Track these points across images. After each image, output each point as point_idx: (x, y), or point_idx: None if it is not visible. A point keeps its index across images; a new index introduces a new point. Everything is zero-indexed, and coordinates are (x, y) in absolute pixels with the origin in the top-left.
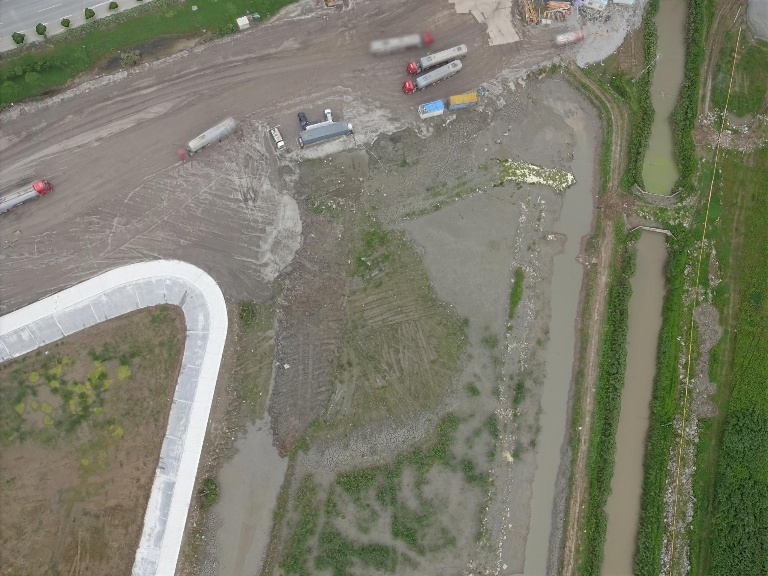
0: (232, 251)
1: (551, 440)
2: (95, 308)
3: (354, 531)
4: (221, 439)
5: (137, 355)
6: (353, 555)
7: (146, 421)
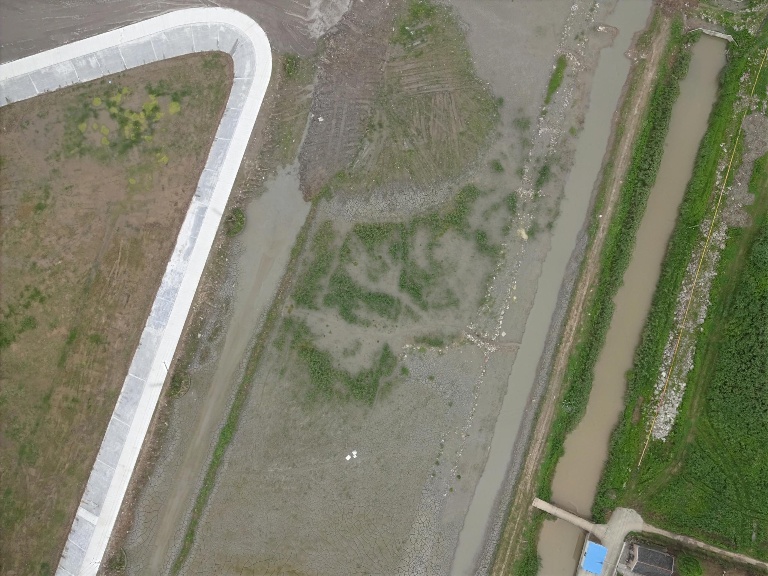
0: (284, 6)
1: (569, 226)
2: (155, 46)
3: (364, 278)
4: (253, 175)
5: (187, 94)
6: (360, 298)
7: (189, 153)
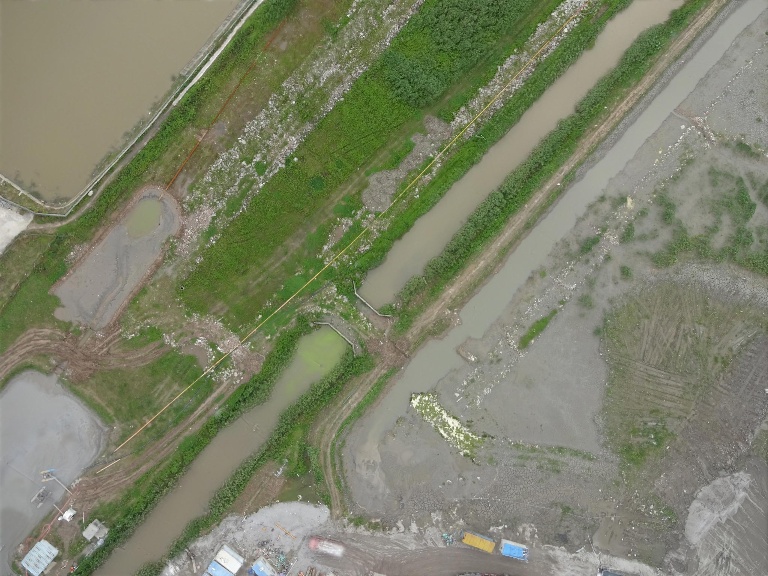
0: (763, 519)
1: (584, 192)
2: None
3: None
4: None
5: None
6: None
7: None
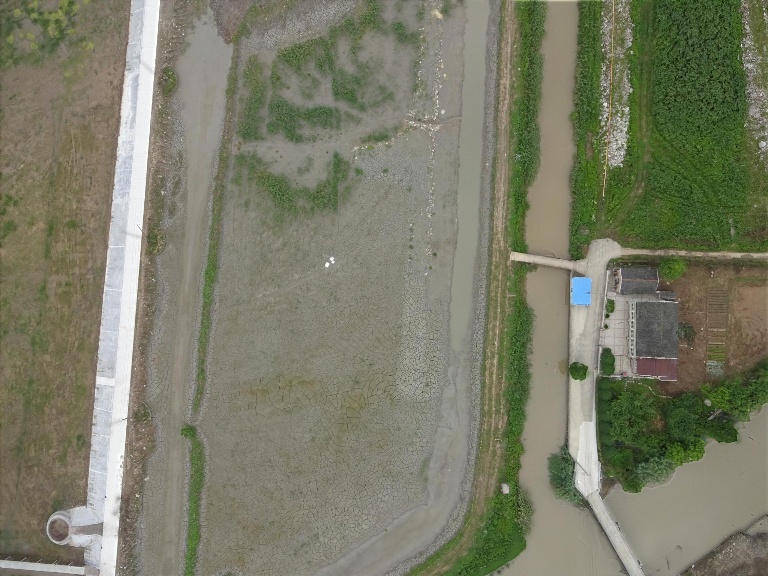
0: None
1: None
2: None
3: (299, 98)
4: (172, 34)
5: None
6: (299, 116)
7: (111, 35)
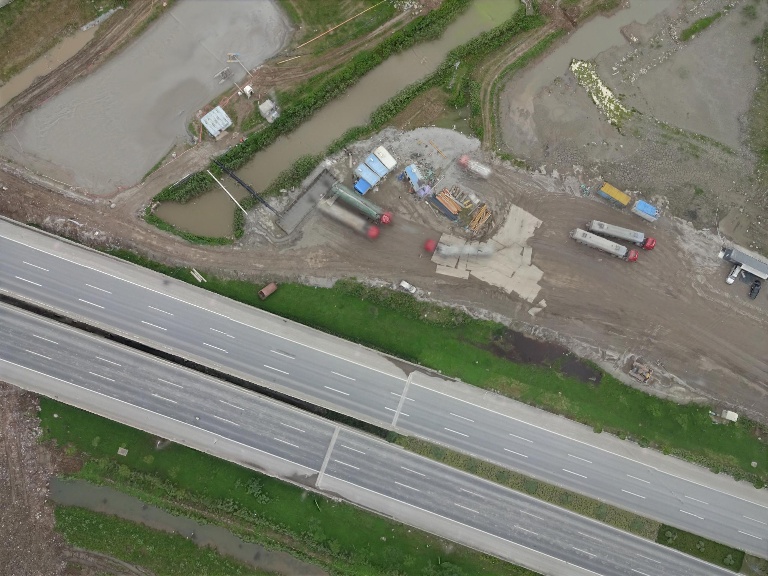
0: None
1: None
2: None
3: None
4: None
5: None
6: None
7: None
